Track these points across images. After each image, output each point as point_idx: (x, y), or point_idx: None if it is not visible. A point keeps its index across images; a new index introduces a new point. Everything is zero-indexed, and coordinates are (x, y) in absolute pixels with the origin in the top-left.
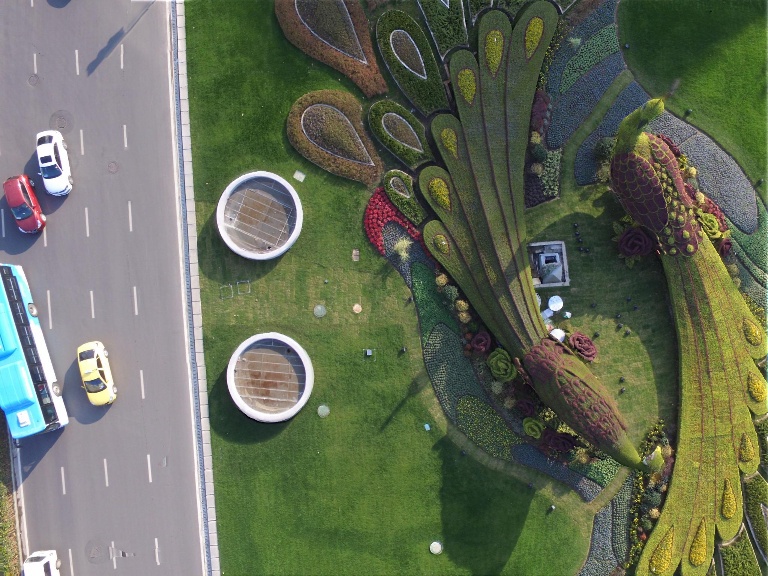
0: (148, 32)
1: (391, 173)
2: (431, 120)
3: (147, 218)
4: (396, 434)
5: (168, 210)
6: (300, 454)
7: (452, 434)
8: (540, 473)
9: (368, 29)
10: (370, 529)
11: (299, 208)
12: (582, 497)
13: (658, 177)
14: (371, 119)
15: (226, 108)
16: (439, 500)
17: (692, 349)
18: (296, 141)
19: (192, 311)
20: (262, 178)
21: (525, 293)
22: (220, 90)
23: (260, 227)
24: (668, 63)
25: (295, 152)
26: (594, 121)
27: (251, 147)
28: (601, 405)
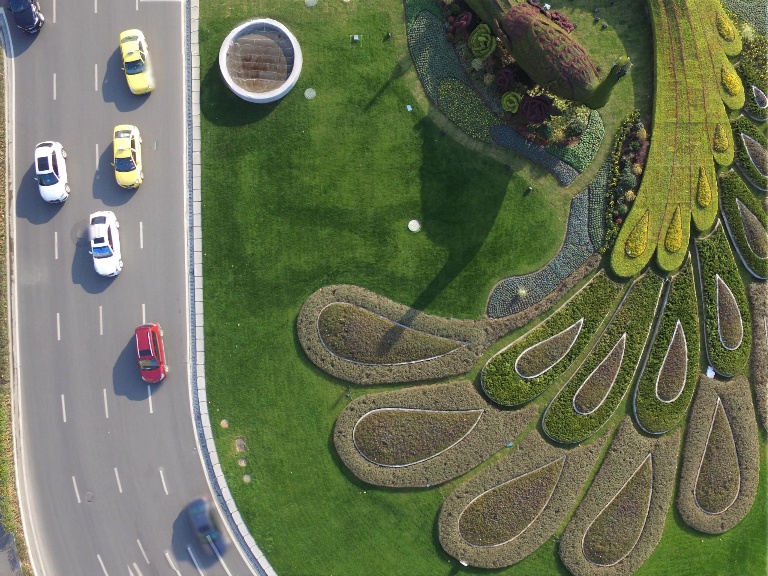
0: None
1: None
2: None
3: None
4: (379, 114)
5: None
6: (286, 134)
7: (433, 115)
8: (518, 155)
9: None
10: (350, 206)
11: None
12: (559, 181)
13: None
14: None
15: None
16: (419, 178)
17: (666, 37)
18: None
19: (190, 5)
20: None
21: None
22: None
23: None
24: None
25: None
26: None
27: None
28: (575, 48)
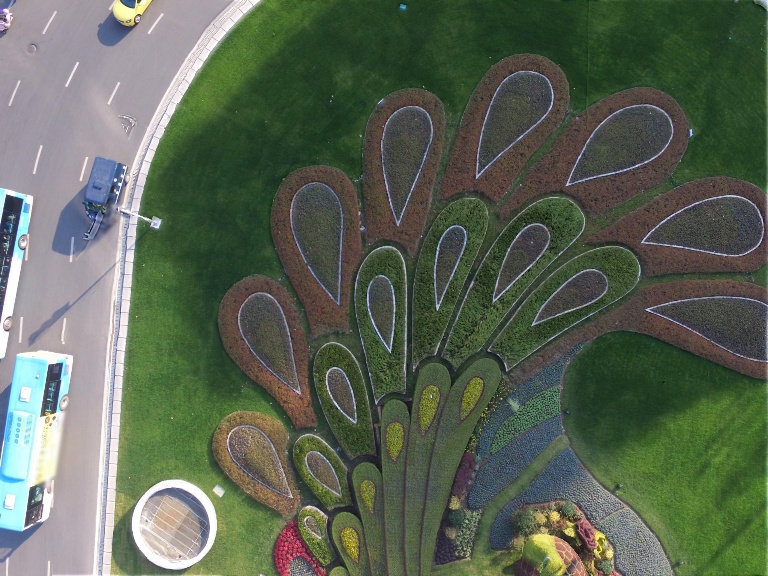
0: (91, 313)
1: (306, 512)
2: (355, 464)
3: (68, 498)
4: None
5: (89, 494)
6: None
7: None
8: None
9: (307, 357)
10: None
11: (212, 528)
12: None
13: None
14: (295, 454)
15: (157, 407)
16: None
17: None
18: (219, 459)
19: None
20: (181, 489)
21: None
22: (154, 388)
23: (174, 534)
24: (608, 433)
25: (218, 467)
26: (520, 486)
27: (176, 453)
28: None
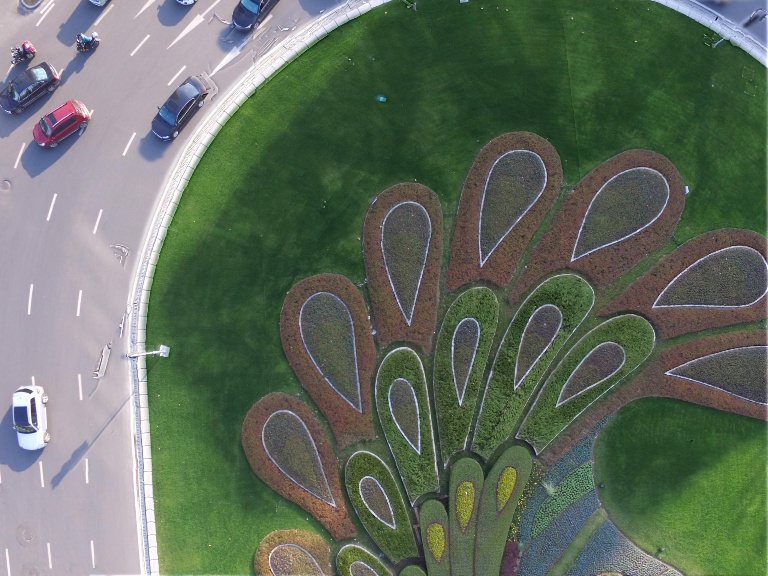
0: (113, 451)
1: None
2: (399, 568)
3: None
4: None
5: None
6: None
7: None
8: None
9: (337, 469)
10: None
11: None
12: None
13: None
14: (339, 567)
15: (193, 536)
16: None
17: None
18: None
19: None
20: None
21: None
22: (187, 518)
23: None
24: (644, 500)
25: None
26: (564, 565)
27: None
28: None
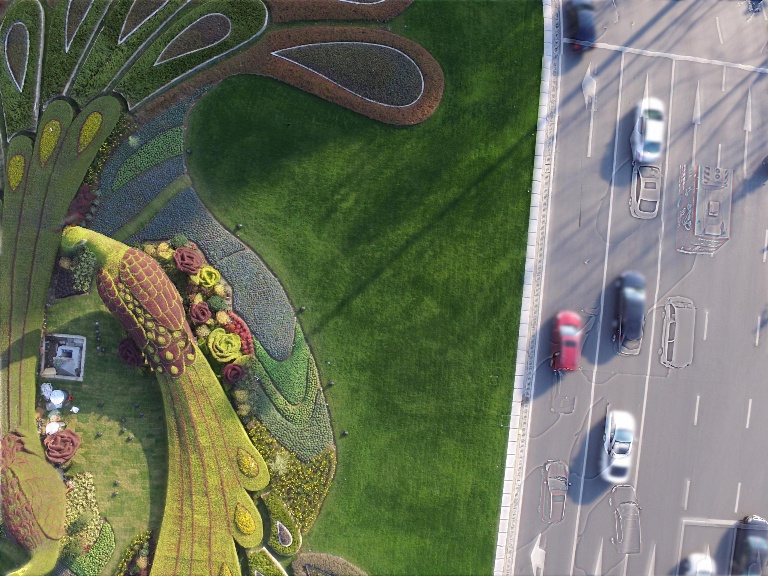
0: None
1: None
2: None
3: None
4: None
5: None
6: None
7: None
8: (29, 556)
9: None
10: None
11: None
12: None
13: (120, 298)
14: None
15: None
16: None
17: (178, 469)
18: None
19: None
20: None
21: (10, 384)
22: None
23: None
24: (229, 173)
25: None
26: (139, 222)
27: None
28: (25, 511)
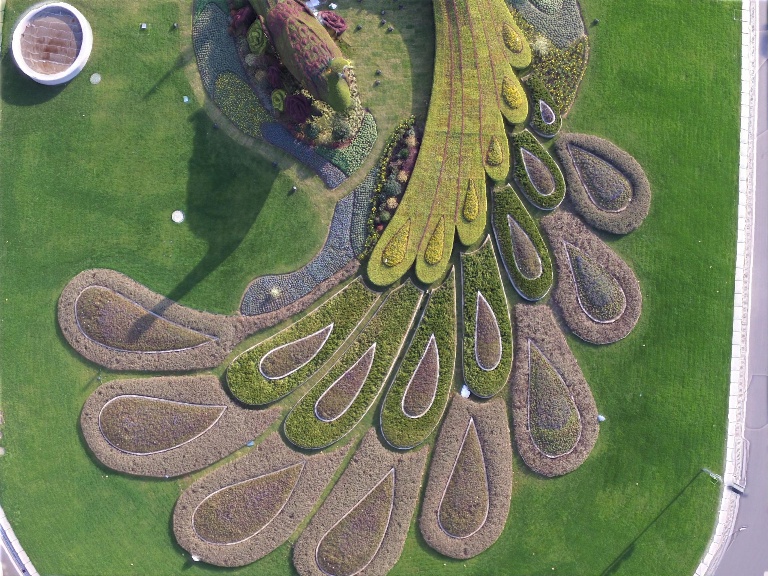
0: None
1: None
2: None
3: None
4: (156, 103)
5: None
6: (68, 117)
7: (208, 107)
8: (286, 153)
9: None
10: (119, 192)
11: None
12: (325, 183)
13: None
14: None
15: None
16: (187, 170)
17: (446, 44)
18: None
19: None
20: None
21: None
22: None
23: None
24: None
25: None
26: None
27: None
28: (321, 48)
